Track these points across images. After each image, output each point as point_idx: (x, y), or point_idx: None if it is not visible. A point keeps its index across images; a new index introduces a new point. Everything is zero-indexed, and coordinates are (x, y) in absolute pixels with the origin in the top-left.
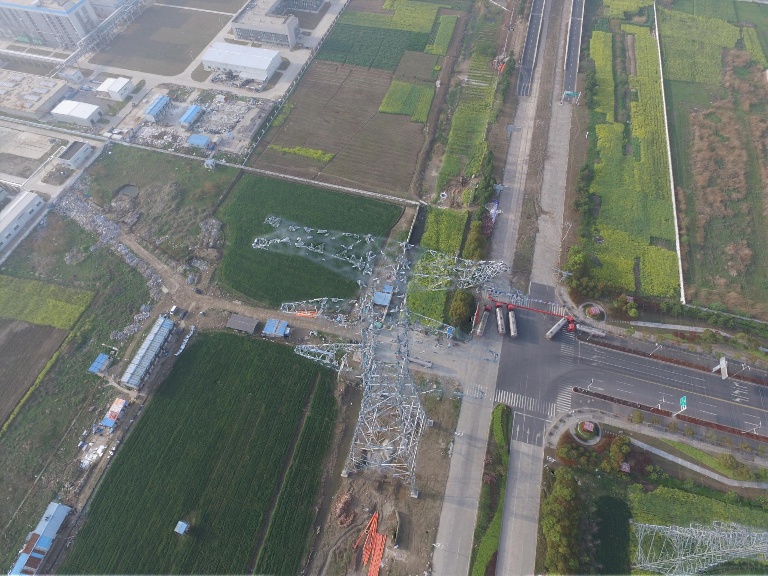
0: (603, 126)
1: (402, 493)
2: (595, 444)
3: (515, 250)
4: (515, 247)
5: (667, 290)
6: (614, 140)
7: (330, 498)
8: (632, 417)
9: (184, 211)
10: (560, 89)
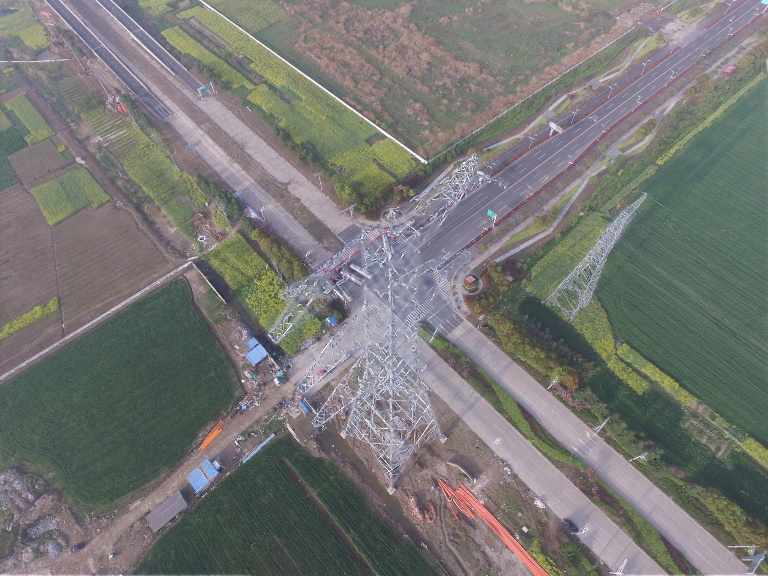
0: (252, 95)
1: (436, 449)
2: (483, 285)
3: (301, 225)
4: (299, 224)
5: (410, 163)
6: (271, 98)
7: (403, 518)
8: (479, 250)
9: None
10: (189, 91)
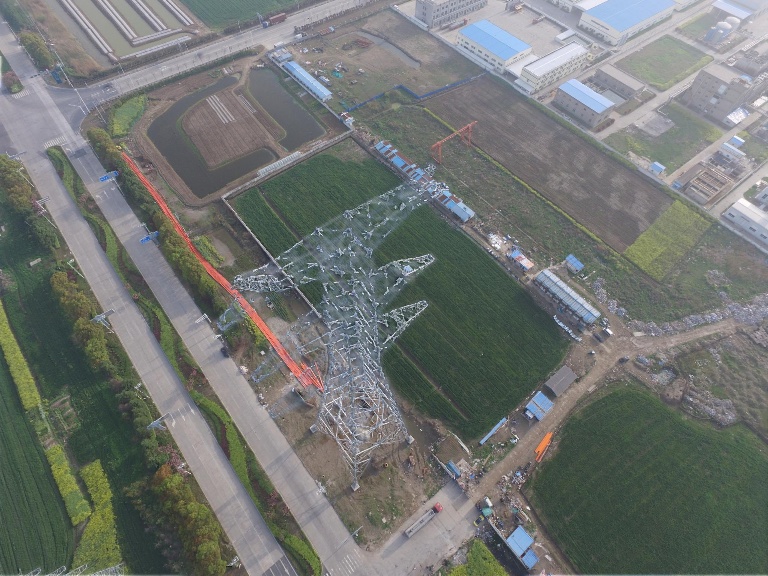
0: None
1: None
2: None
3: None
4: None
5: None
6: None
7: (360, 367)
8: None
9: (759, 393)
10: None
